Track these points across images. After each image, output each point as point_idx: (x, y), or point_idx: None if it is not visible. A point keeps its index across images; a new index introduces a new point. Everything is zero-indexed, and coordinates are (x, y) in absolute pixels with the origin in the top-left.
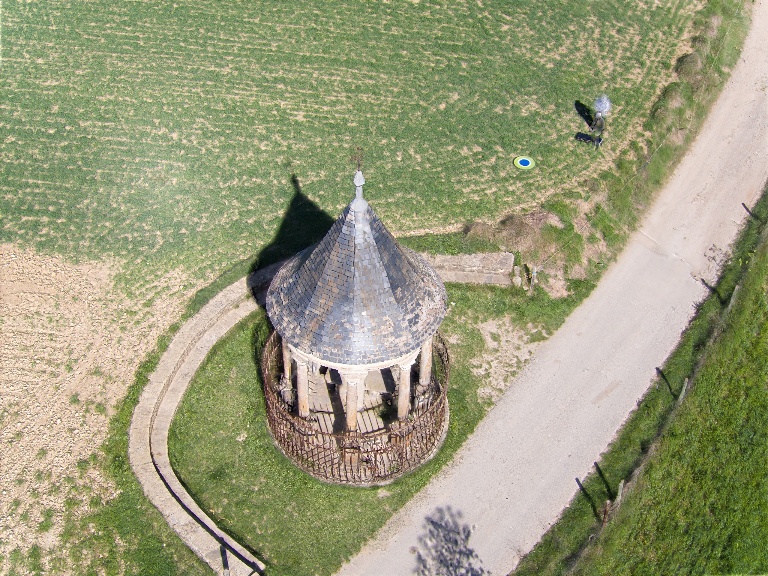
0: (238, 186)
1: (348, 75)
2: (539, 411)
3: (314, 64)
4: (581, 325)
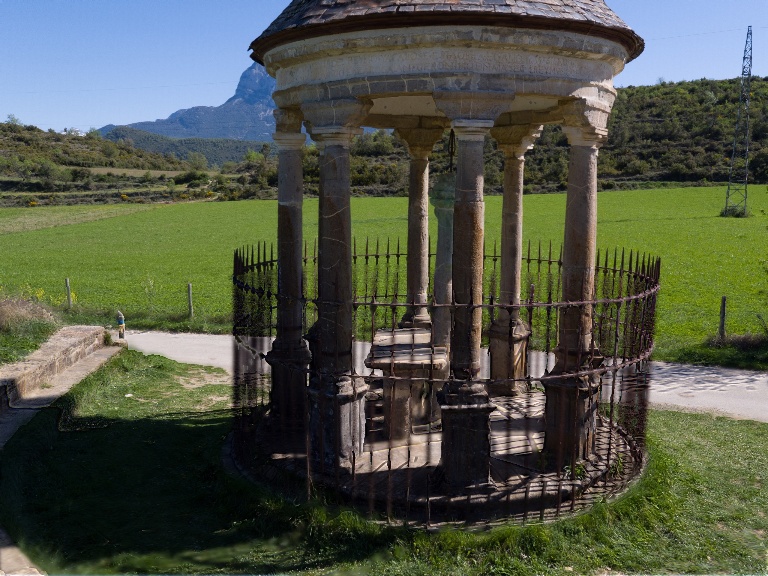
0: None
1: None
2: None
3: None
4: (195, 359)
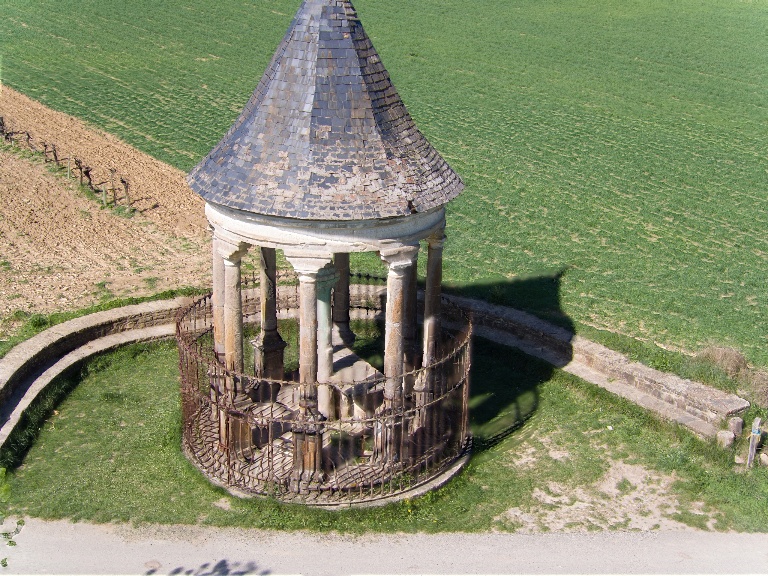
0: None
1: (765, 237)
2: (565, 575)
3: (734, 219)
4: None
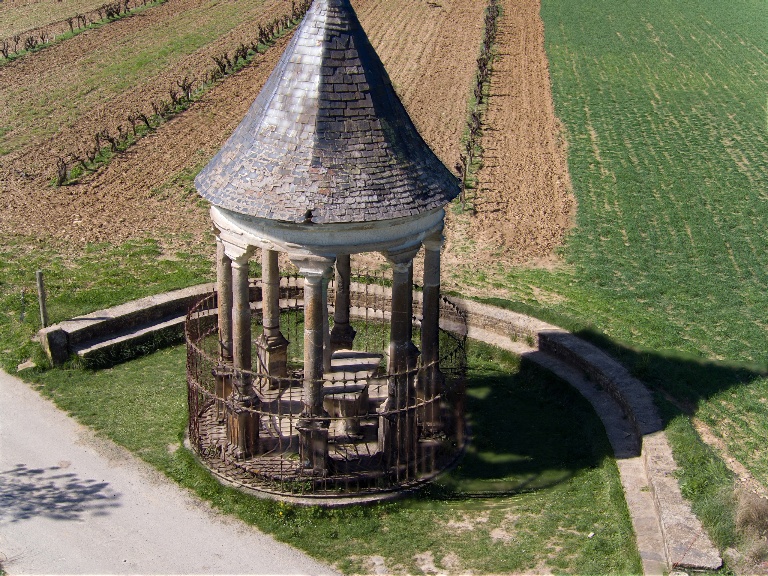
0: (761, 330)
1: None
2: None
3: None
4: None
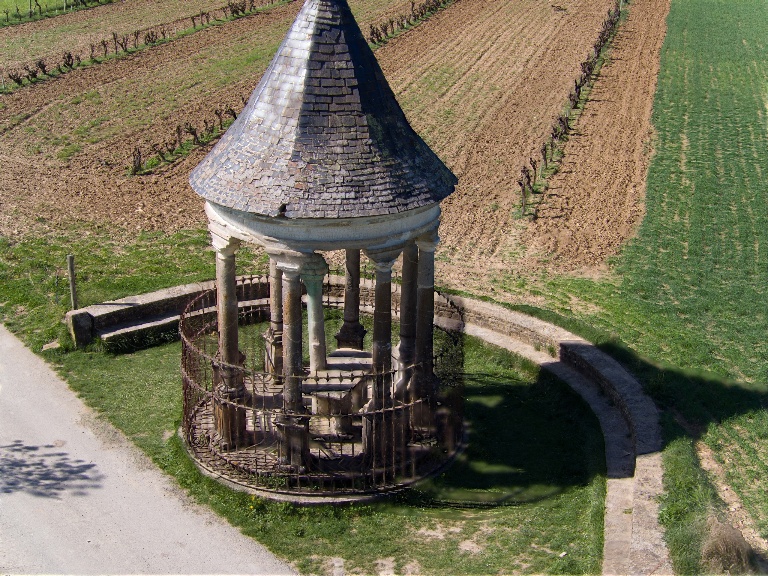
0: None
1: None
2: None
3: None
4: None
